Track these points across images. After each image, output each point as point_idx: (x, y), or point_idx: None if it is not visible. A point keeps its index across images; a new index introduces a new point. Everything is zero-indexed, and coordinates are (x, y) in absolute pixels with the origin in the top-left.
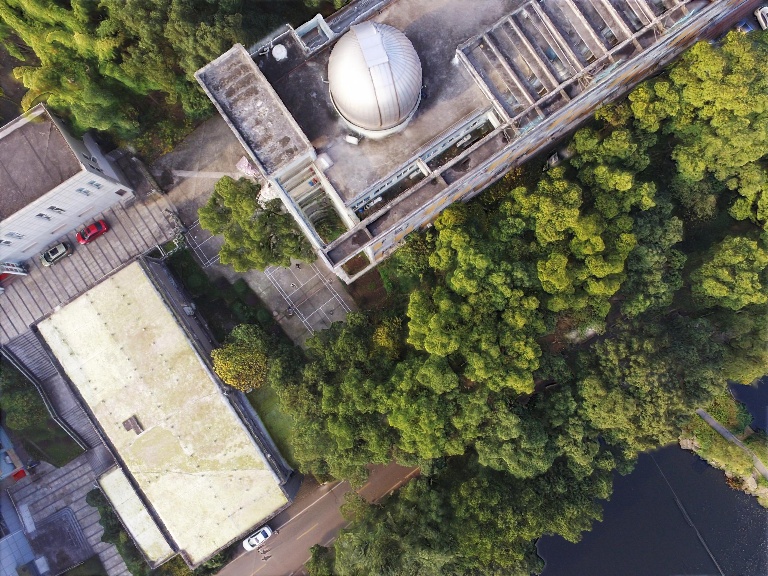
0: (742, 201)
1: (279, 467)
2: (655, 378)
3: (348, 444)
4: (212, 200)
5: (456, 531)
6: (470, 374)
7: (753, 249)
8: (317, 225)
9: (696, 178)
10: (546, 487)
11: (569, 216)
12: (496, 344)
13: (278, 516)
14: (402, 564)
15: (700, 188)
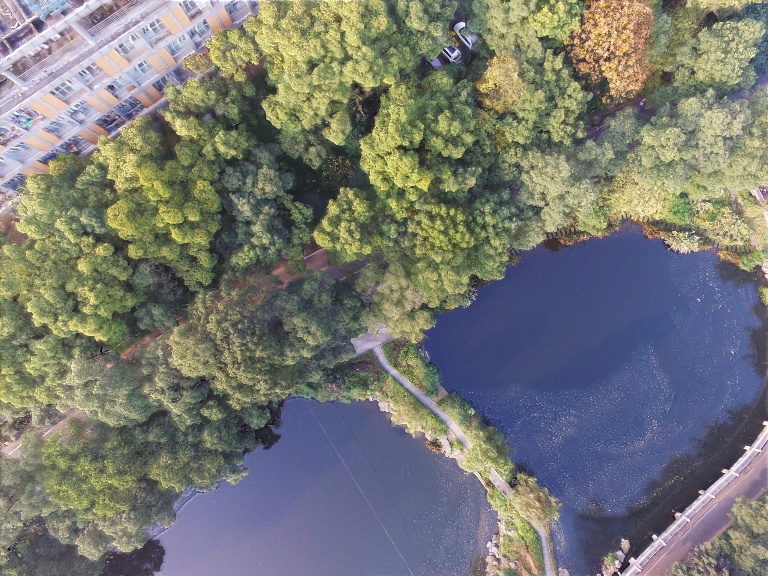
0: None
1: None
2: (227, 324)
3: None
4: None
5: (44, 479)
6: None
7: (352, 198)
8: None
9: (293, 128)
10: (139, 436)
11: (129, 161)
12: (59, 289)
13: None
14: None
15: (309, 139)
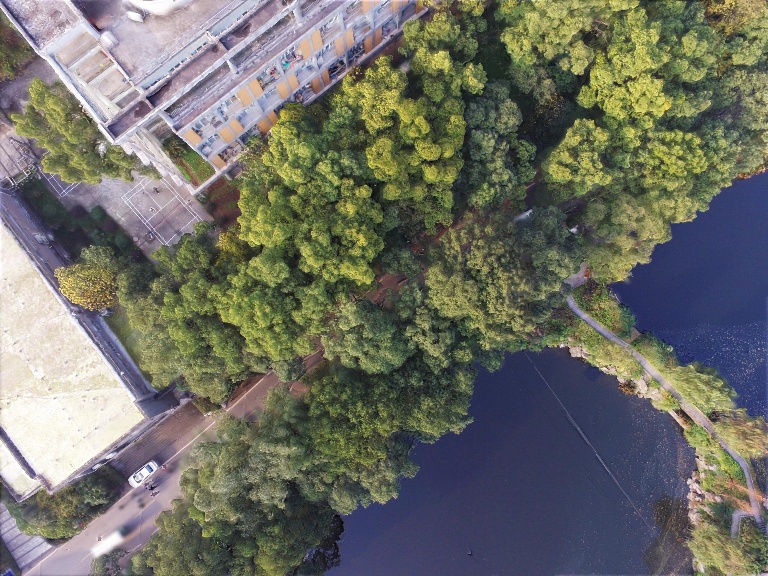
0: (586, 87)
1: (135, 386)
2: (493, 258)
3: (189, 348)
4: (30, 108)
5: (309, 430)
6: (304, 265)
7: (592, 128)
8: (165, 142)
9: (529, 61)
10: (399, 381)
11: (390, 98)
12: (326, 233)
13: (164, 451)
14: (248, 463)
15: (538, 73)
